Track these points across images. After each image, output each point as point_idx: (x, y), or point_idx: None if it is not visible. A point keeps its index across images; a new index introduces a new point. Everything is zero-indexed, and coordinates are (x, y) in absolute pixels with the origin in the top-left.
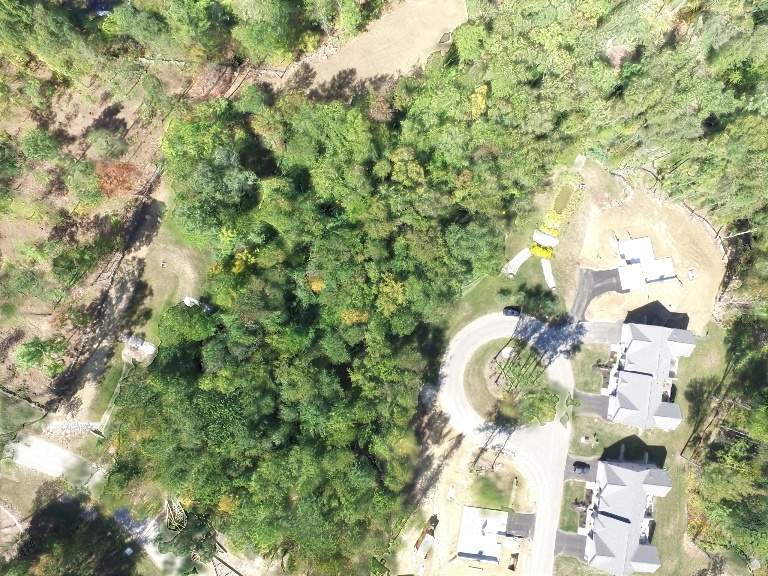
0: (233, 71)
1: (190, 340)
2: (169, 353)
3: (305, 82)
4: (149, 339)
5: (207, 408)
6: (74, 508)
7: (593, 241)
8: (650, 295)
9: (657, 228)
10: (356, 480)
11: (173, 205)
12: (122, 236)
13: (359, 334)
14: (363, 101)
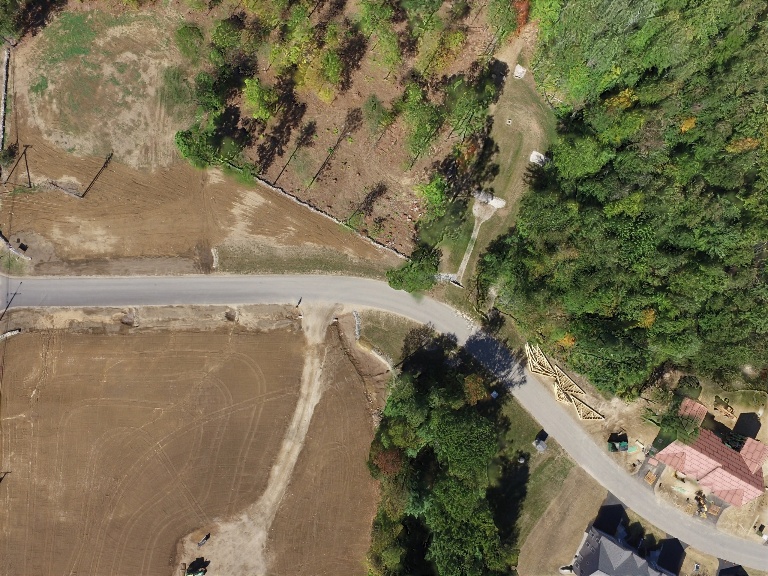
0: None
1: (584, 173)
2: (569, 184)
3: None
4: (497, 194)
5: (620, 230)
6: (439, 355)
7: None
8: None
9: None
10: (767, 292)
11: (514, 66)
12: None
13: (753, 158)
14: None
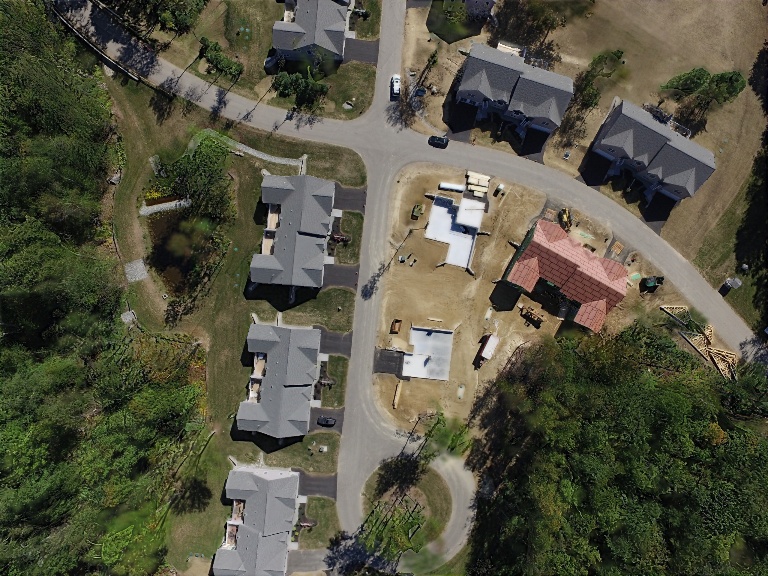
0: None
1: (747, 572)
2: (767, 561)
3: None
4: None
5: None
6: None
7: None
8: None
9: None
10: None
11: None
12: None
13: None
14: None
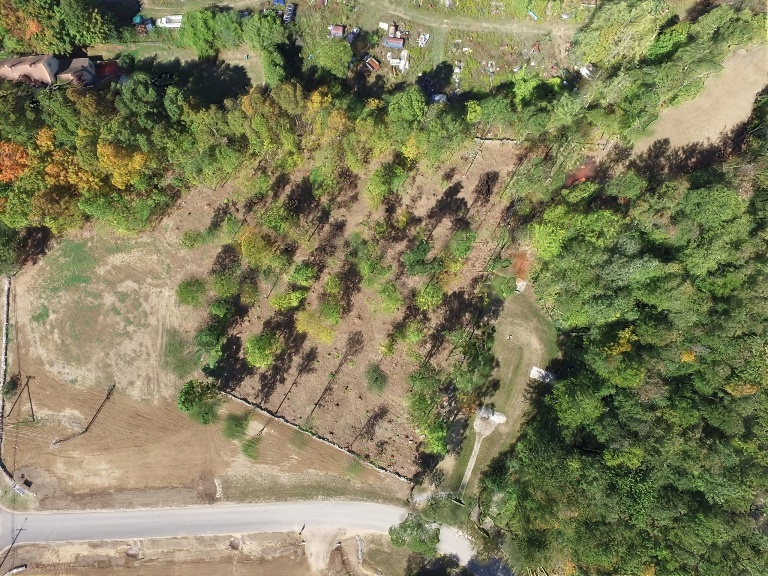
0: (559, 146)
1: None
2: (569, 431)
3: (624, 154)
4: (498, 409)
5: (620, 483)
6: (441, 574)
7: None
8: None
9: None
10: (765, 545)
11: None
12: (471, 312)
13: (752, 406)
14: (722, 179)
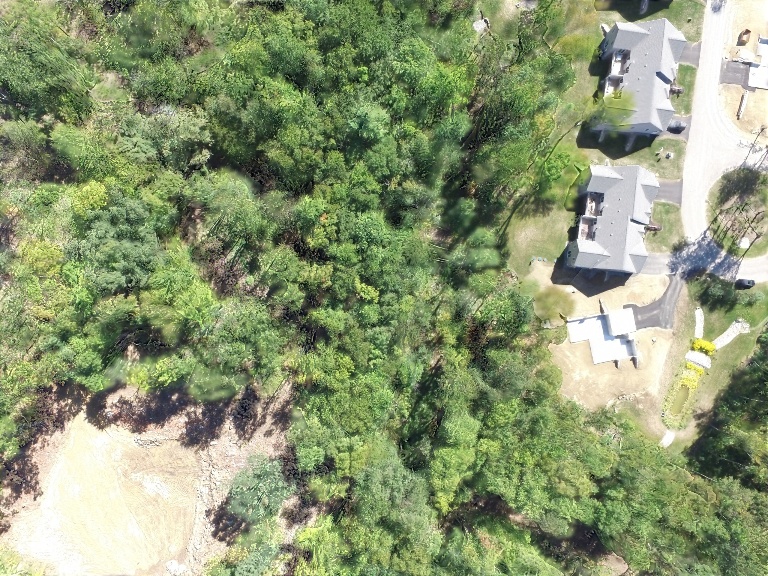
0: None
1: None
2: None
3: None
4: None
5: None
6: None
7: (658, 358)
8: (597, 303)
9: (584, 373)
10: None
11: None
12: None
13: None
14: None
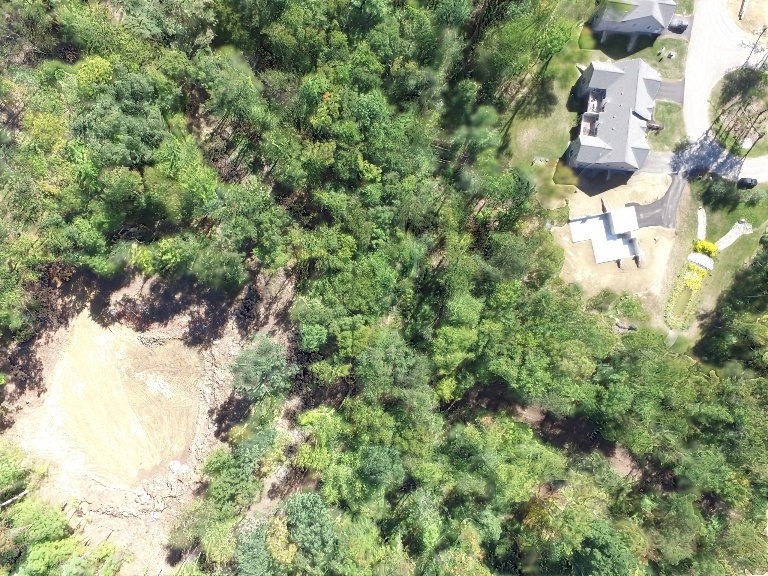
0: None
1: None
2: None
3: None
4: None
5: None
6: None
7: (660, 257)
8: (599, 202)
9: (586, 273)
10: None
11: None
12: None
13: None
14: None
